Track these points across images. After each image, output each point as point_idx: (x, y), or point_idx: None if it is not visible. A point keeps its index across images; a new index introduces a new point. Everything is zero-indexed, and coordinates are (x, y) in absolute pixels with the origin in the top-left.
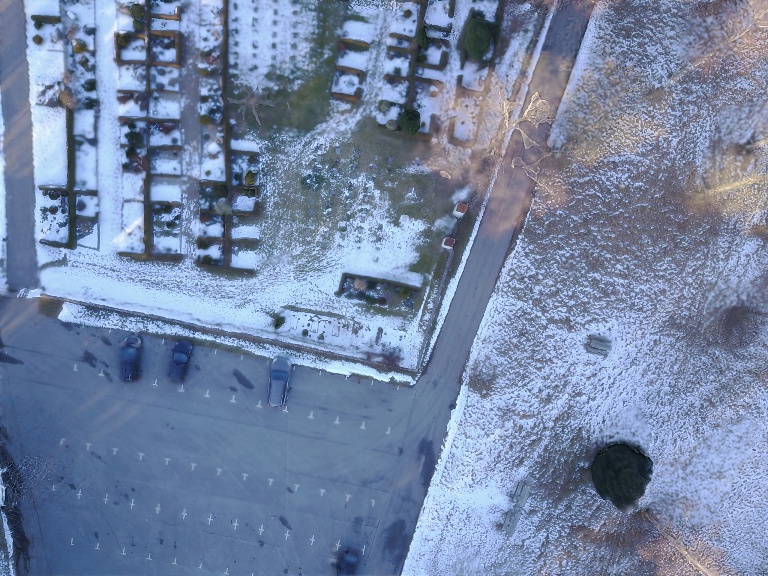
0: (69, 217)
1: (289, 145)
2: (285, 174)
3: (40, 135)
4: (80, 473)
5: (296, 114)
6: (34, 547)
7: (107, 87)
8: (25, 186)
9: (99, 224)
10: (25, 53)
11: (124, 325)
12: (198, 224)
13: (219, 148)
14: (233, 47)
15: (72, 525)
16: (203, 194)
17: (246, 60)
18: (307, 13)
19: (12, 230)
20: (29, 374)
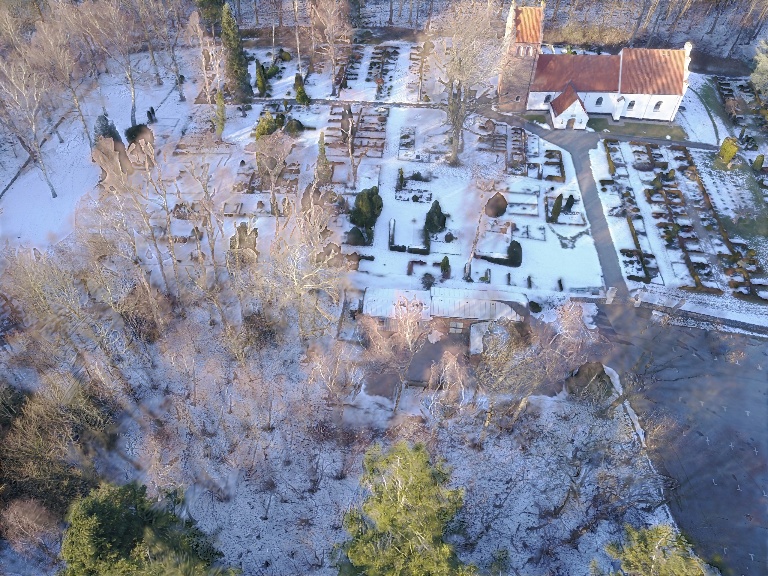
0: (642, 266)
1: (763, 243)
2: (767, 255)
3: (613, 228)
4: (702, 423)
5: (760, 229)
6: (681, 486)
7: (645, 212)
8: (609, 251)
9: (660, 273)
10: (597, 195)
11: (699, 326)
12: (724, 276)
13: (721, 242)
14: (711, 200)
15: (710, 467)
16: (723, 260)
17: (720, 205)
18: (745, 190)
19: (606, 272)
20: (640, 352)
